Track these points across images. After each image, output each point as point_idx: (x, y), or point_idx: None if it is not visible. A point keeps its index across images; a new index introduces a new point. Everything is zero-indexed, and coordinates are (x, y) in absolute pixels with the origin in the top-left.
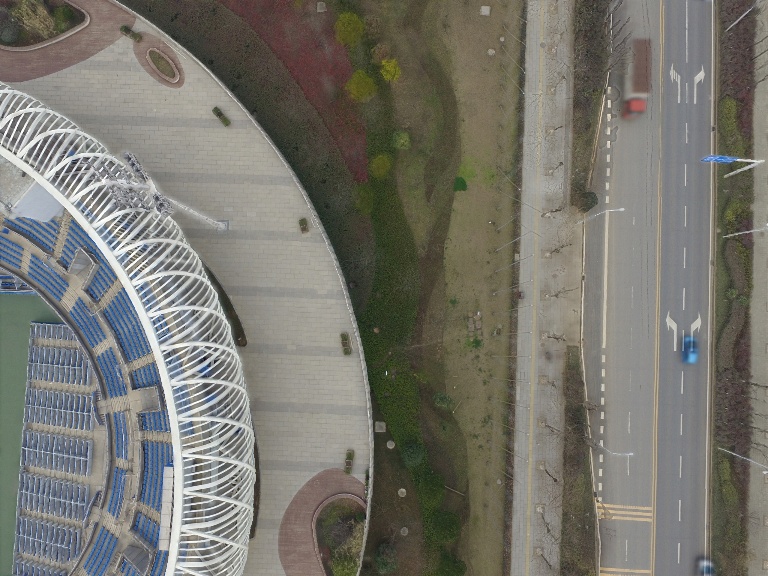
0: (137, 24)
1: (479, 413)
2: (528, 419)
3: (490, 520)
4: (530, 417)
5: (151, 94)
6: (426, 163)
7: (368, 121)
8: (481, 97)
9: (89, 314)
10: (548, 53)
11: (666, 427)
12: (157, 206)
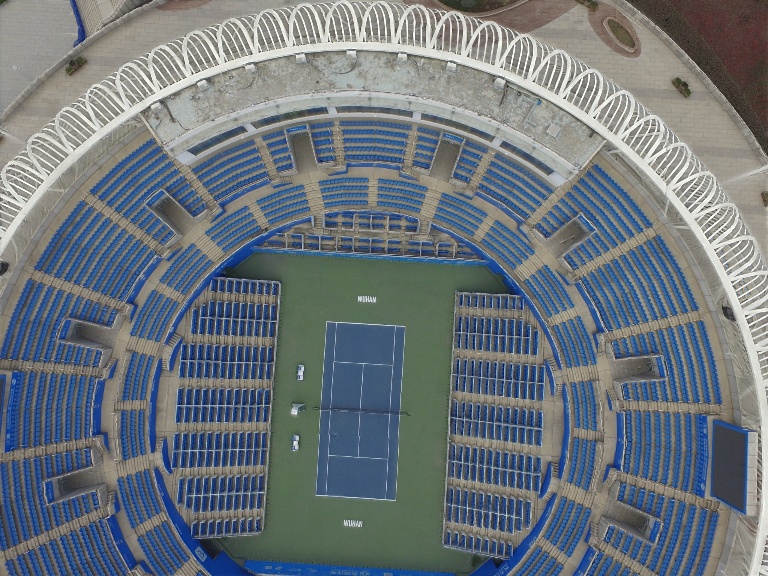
0: None
1: None
2: None
3: None
4: None
5: (608, 63)
6: None
7: None
8: None
9: None
10: None
11: None
12: None
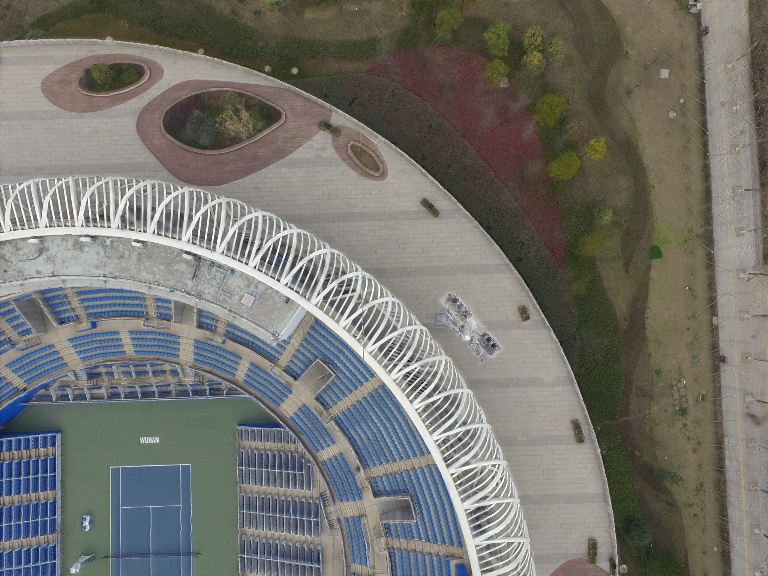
0: (334, 118)
1: (691, 482)
2: (739, 483)
3: None
4: (741, 481)
5: (355, 189)
6: (622, 234)
7: (561, 195)
8: (668, 161)
9: (324, 423)
10: (729, 111)
11: None
12: (484, 345)
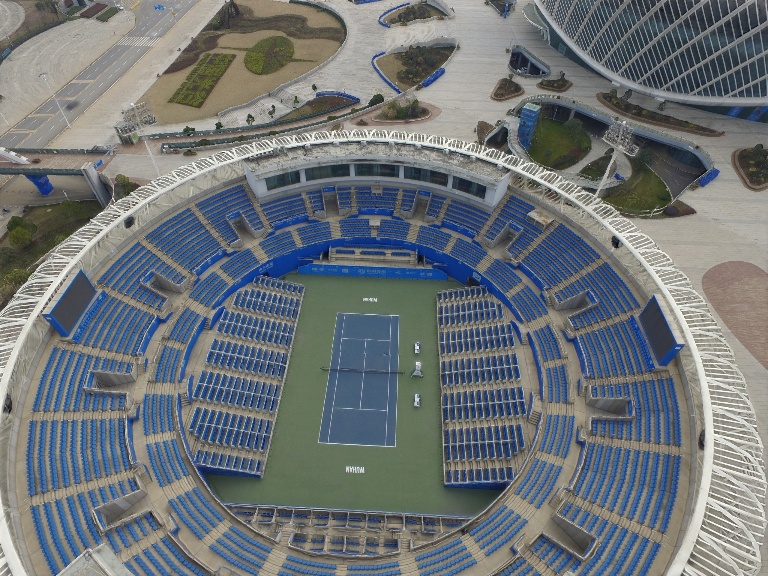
0: None
1: None
2: None
3: None
4: None
5: None
6: None
7: None
8: None
9: None
10: None
11: None
12: None
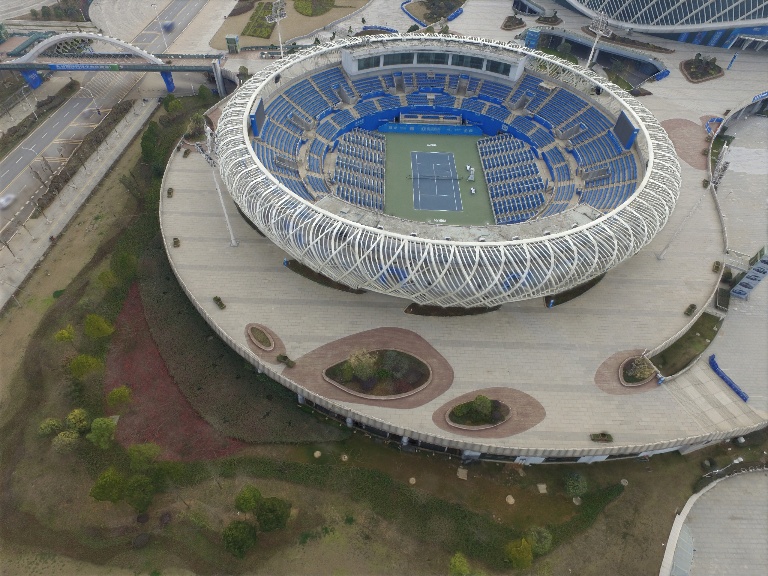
0: (280, 371)
1: (113, 191)
2: (85, 190)
3: (130, 156)
4: (83, 191)
5: (275, 319)
6: None
7: None
8: (3, 355)
9: None
10: None
11: (1, 187)
12: None
